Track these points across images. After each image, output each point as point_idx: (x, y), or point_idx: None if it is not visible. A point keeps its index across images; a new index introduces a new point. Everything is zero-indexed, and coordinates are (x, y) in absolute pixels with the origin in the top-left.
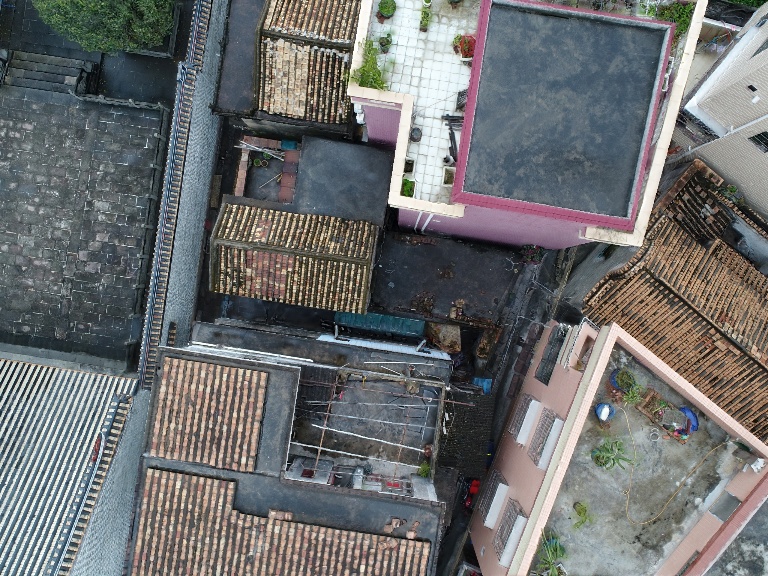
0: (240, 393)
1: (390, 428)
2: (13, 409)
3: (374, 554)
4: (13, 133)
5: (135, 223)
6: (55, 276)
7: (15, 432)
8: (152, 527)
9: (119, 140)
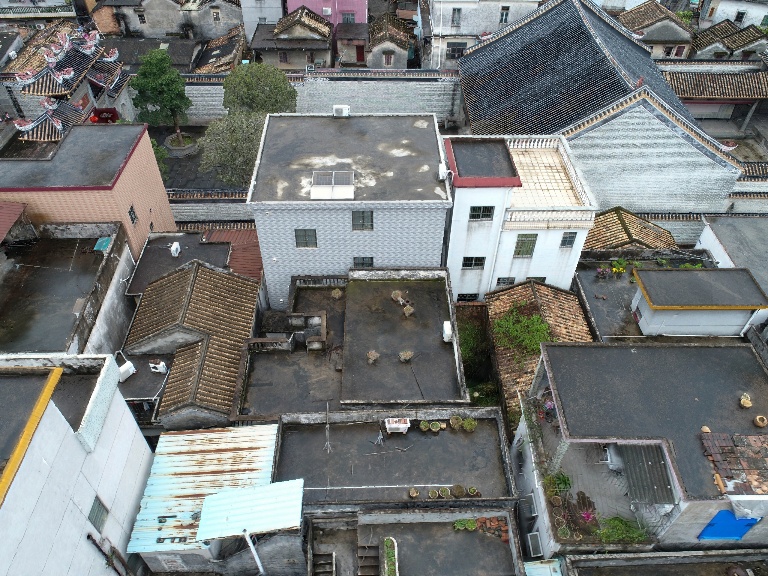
0: None
1: None
2: None
3: None
4: None
5: None
6: None
7: None
8: None
9: None
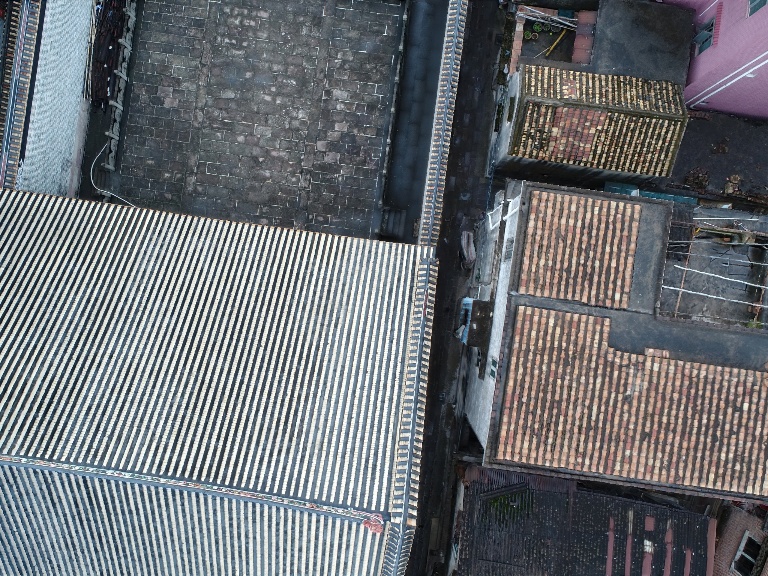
0: (613, 227)
1: (714, 286)
2: (316, 274)
3: (758, 391)
4: (248, 21)
5: (375, 112)
6: (293, 167)
7: (323, 295)
8: (524, 367)
9: (357, 27)
